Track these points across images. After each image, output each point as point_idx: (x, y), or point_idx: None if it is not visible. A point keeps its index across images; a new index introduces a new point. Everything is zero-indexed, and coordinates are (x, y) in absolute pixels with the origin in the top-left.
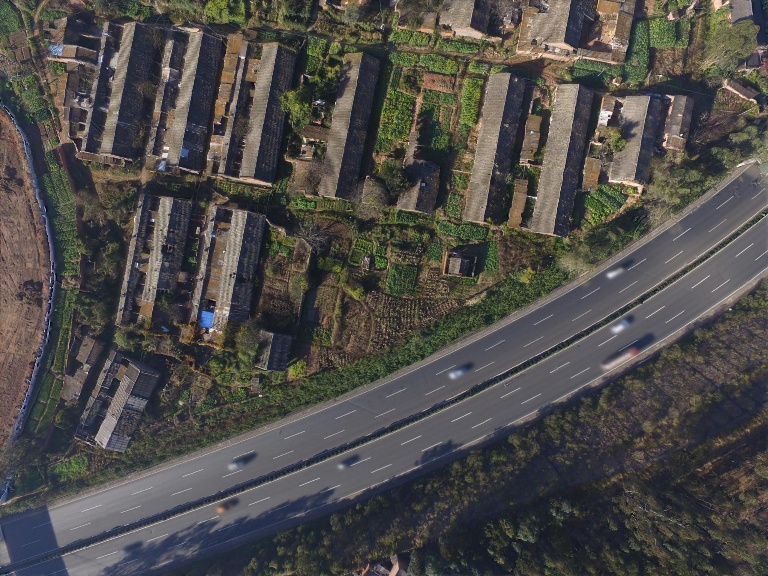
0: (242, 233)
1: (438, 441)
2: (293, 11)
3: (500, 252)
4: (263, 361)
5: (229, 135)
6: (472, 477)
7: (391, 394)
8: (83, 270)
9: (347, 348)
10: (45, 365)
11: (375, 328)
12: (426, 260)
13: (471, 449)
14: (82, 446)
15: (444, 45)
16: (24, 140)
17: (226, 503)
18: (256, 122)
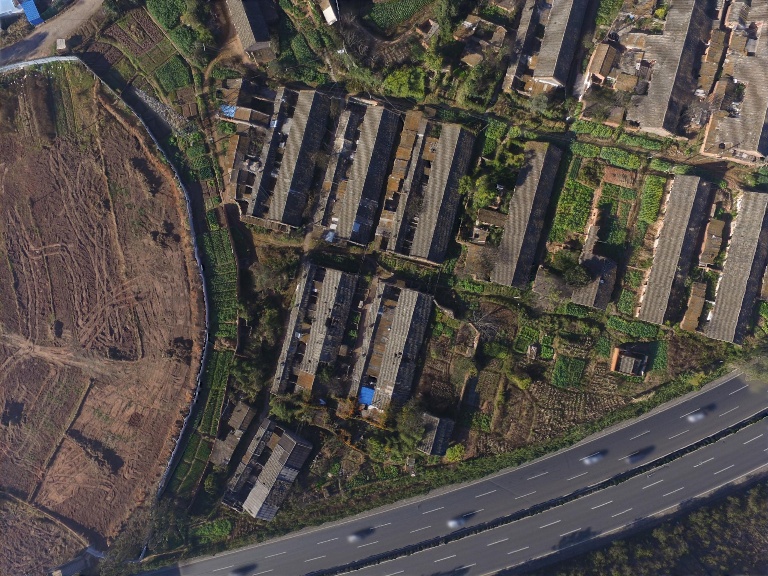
0: (411, 313)
1: (577, 527)
2: (476, 93)
3: (670, 352)
4: (426, 445)
5: (401, 212)
6: (618, 571)
7: (533, 476)
8: (239, 334)
9: (507, 435)
10: (192, 425)
11: (538, 419)
12: (594, 354)
13: (611, 538)
14: (226, 510)
15: (627, 140)
16: (186, 197)
17: (359, 573)
18: (432, 202)
